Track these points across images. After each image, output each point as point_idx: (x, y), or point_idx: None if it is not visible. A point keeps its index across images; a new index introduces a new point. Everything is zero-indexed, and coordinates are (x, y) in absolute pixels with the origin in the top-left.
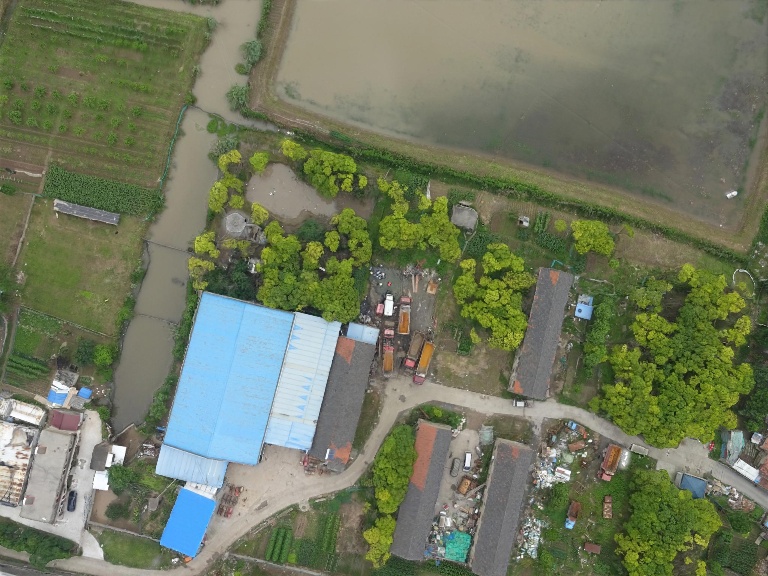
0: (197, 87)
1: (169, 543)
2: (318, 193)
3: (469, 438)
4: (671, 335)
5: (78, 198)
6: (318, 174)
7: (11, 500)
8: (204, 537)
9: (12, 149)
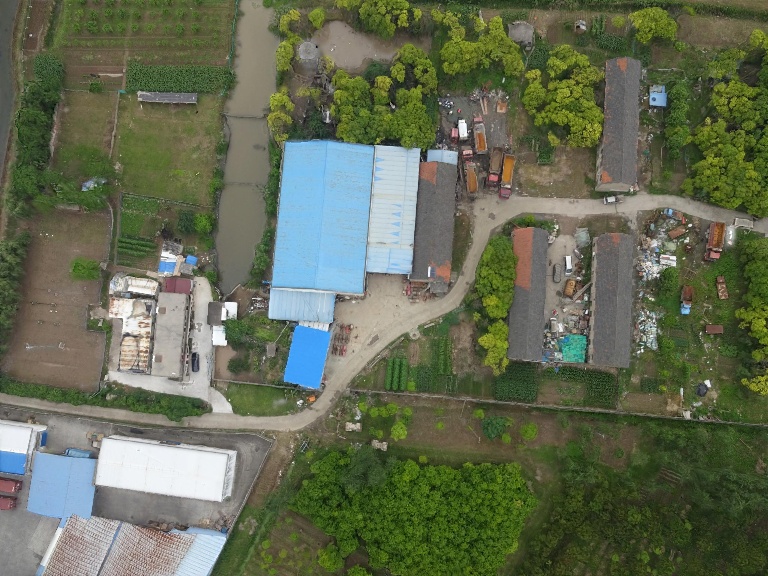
0: None
1: (293, 379)
2: (376, 37)
3: (565, 243)
4: (754, 98)
5: (158, 87)
6: (374, 14)
7: (140, 367)
8: (324, 377)
9: (93, 56)
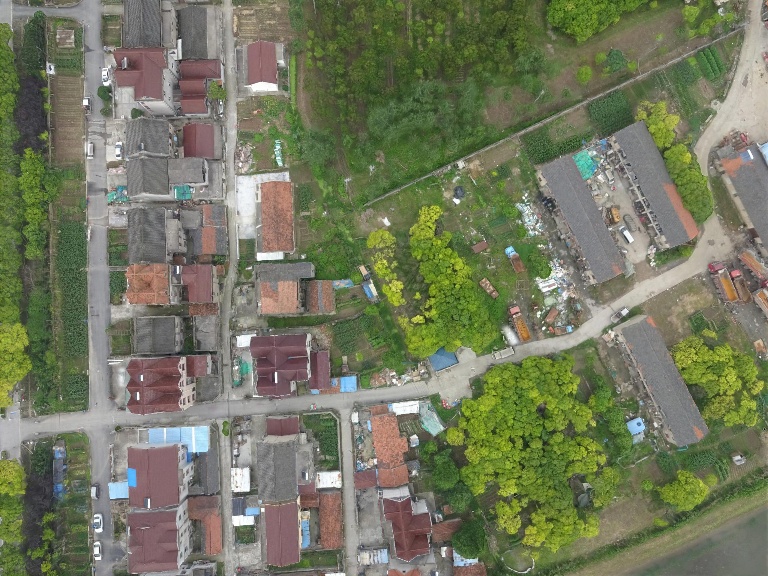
0: None
1: None
2: None
3: (637, 254)
4: (569, 465)
5: None
6: None
7: None
8: None
9: None
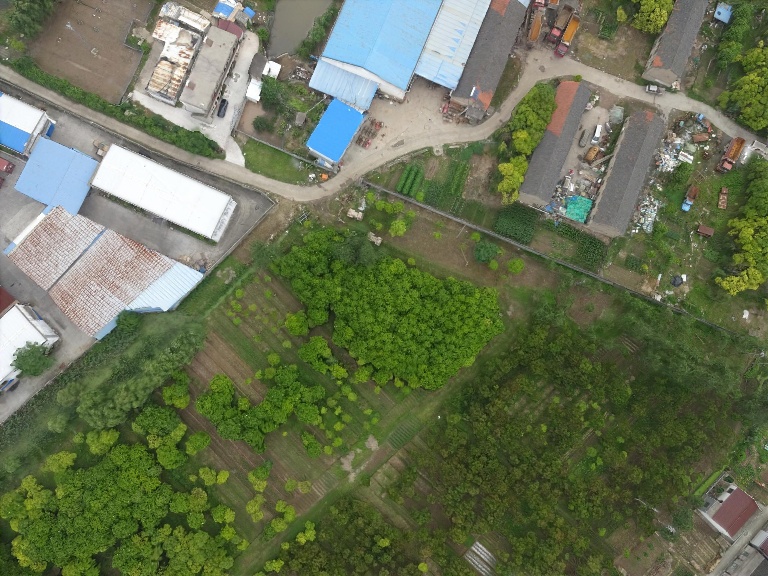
0: None
1: (315, 146)
2: None
3: (600, 115)
4: None
5: None
6: None
7: (169, 93)
8: (341, 162)
9: None
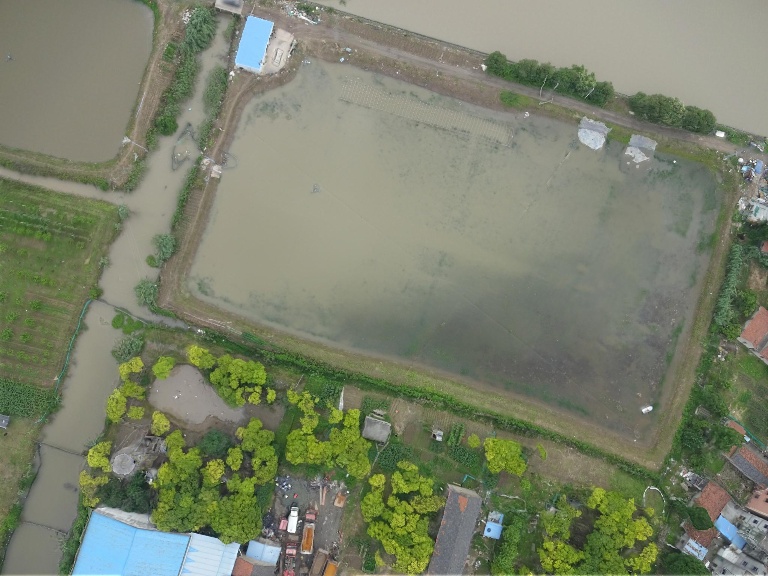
0: (104, 278)
1: None
2: (225, 402)
3: None
4: (577, 565)
5: None
6: (224, 387)
7: None
8: None
9: None
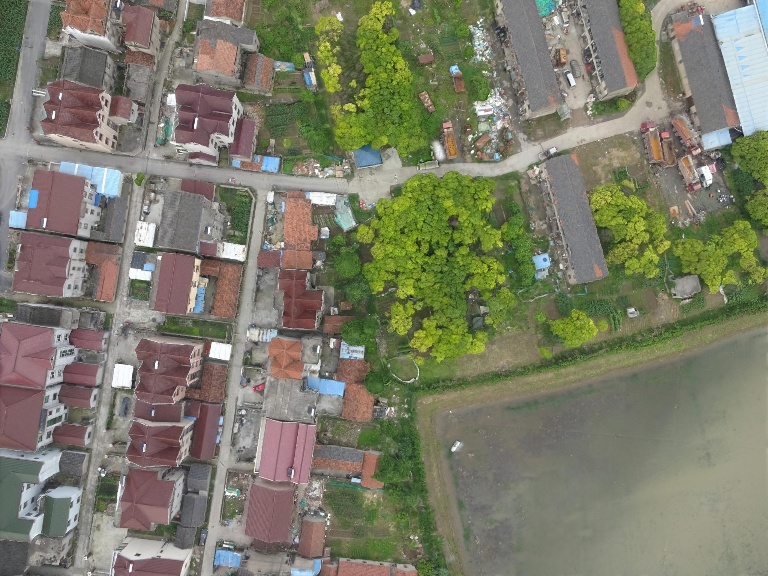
0: None
1: None
2: None
3: (576, 100)
4: (469, 277)
5: None
6: None
7: None
8: None
9: None
